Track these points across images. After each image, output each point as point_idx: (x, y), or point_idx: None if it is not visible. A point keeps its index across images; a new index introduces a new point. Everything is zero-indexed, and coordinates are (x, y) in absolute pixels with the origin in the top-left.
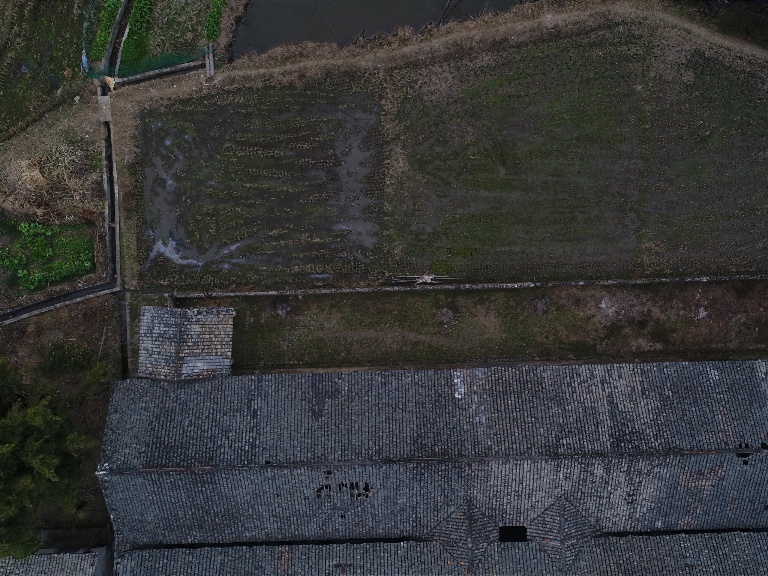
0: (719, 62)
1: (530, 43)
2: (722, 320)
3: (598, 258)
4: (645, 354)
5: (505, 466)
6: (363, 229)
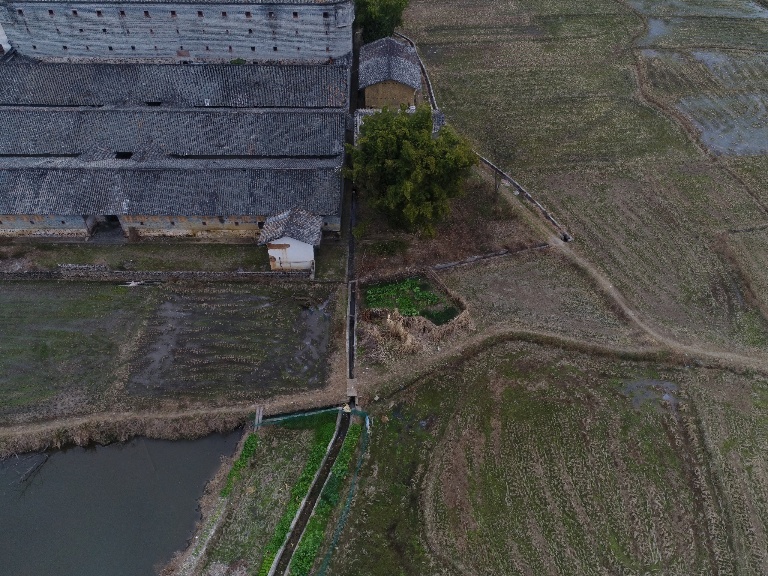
0: None
1: None
2: None
3: (7, 292)
4: (6, 244)
5: None
6: (169, 312)
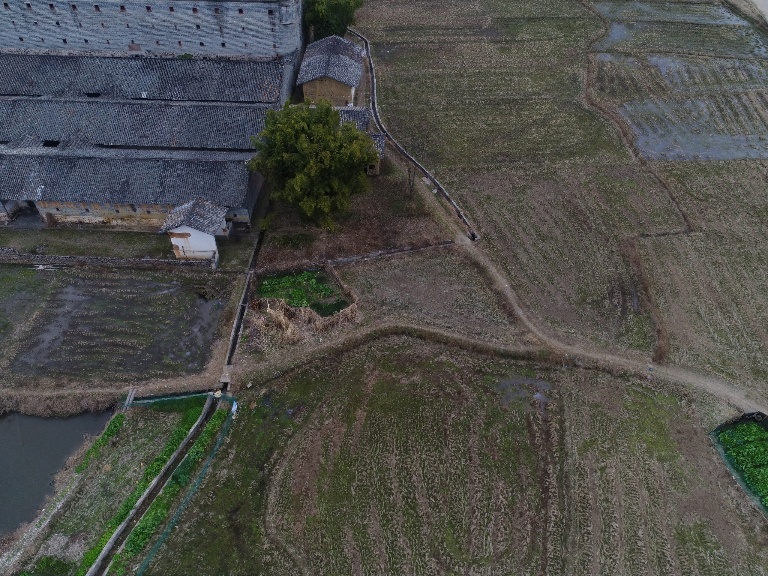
0: None
1: None
2: None
3: None
4: None
5: None
6: (69, 296)
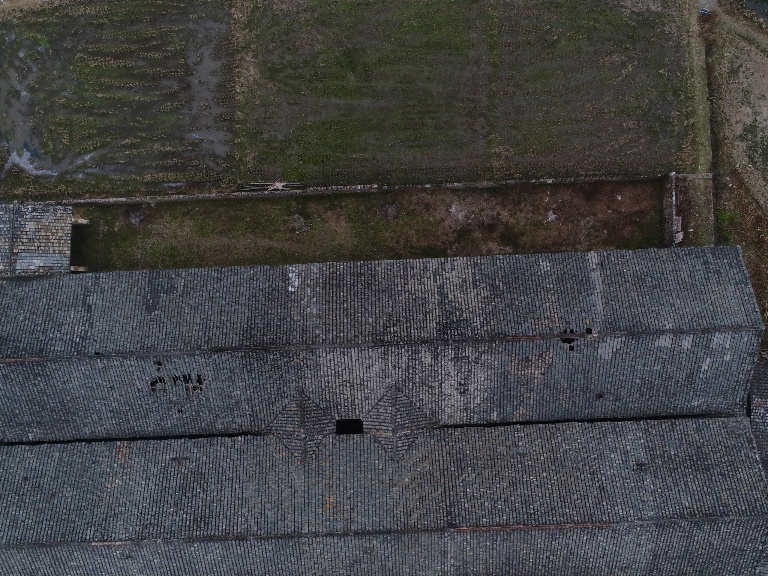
0: None
1: None
2: (571, 223)
3: (448, 163)
4: None
5: (333, 354)
6: (215, 138)
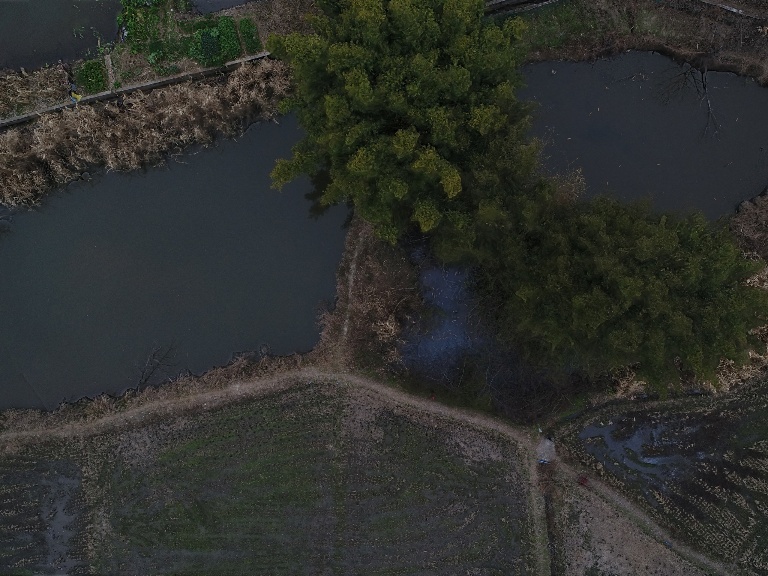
0: (408, 419)
1: (224, 407)
2: None
3: None
4: None
5: None
6: None
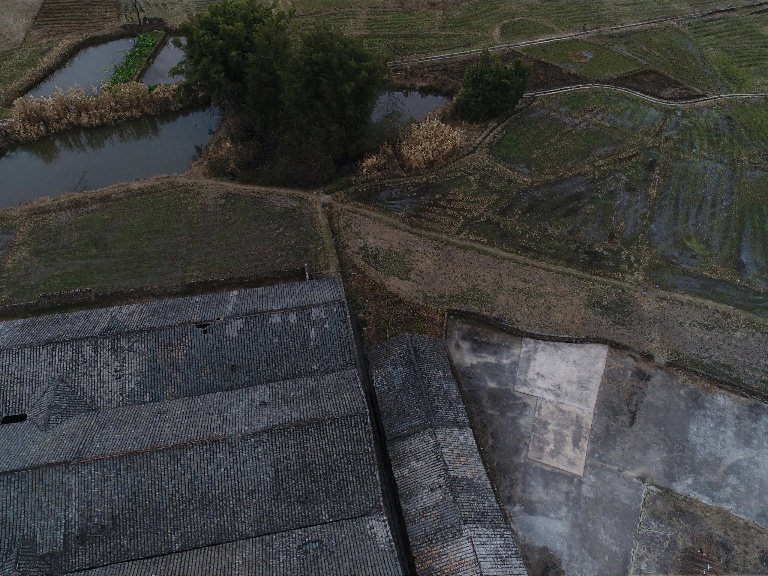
0: (240, 195)
1: (125, 198)
2: None
3: (154, 284)
4: None
5: (9, 356)
6: None
